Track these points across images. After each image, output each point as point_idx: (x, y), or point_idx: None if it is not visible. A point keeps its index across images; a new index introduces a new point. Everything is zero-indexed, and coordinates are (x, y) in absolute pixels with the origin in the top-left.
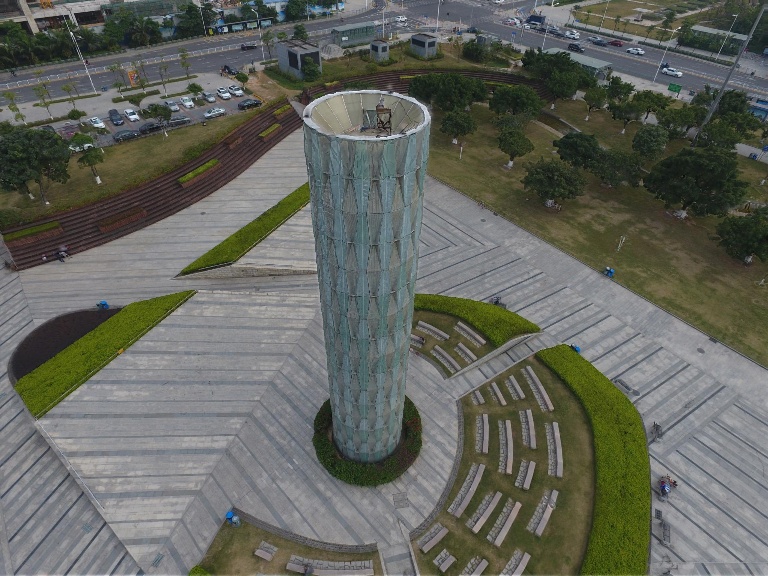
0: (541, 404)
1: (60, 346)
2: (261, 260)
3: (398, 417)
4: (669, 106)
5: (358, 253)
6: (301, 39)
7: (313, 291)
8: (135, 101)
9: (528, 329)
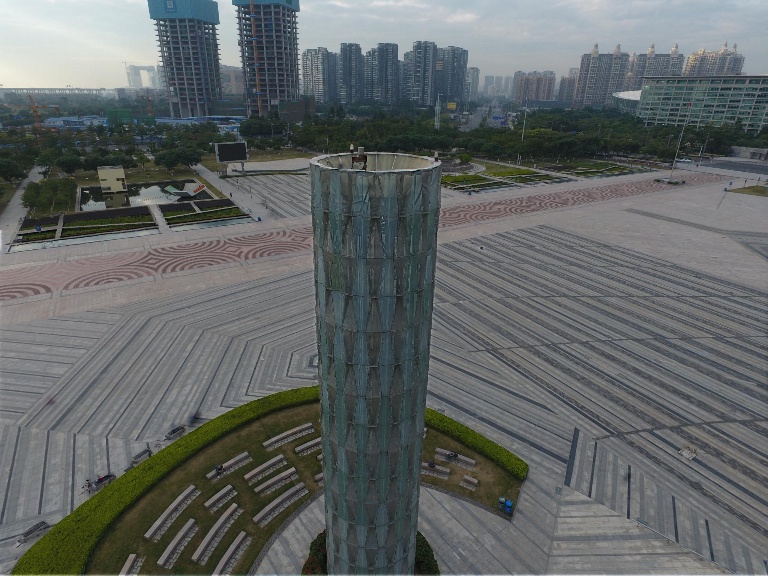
0: (138, 568)
1: None
2: None
3: None
4: None
5: None
6: None
7: None
8: None
9: None
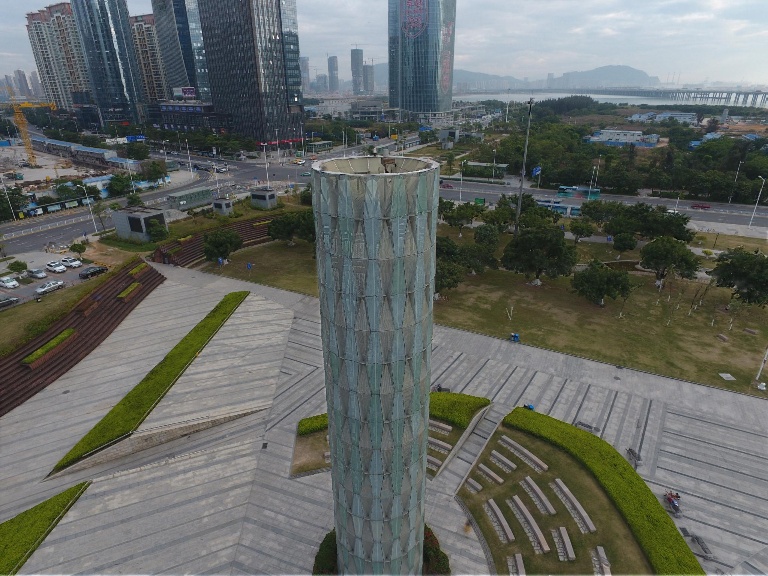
0: (534, 467)
1: None
2: (168, 421)
3: None
4: (485, 211)
5: (394, 306)
6: (140, 205)
7: (244, 437)
8: None
9: (482, 403)
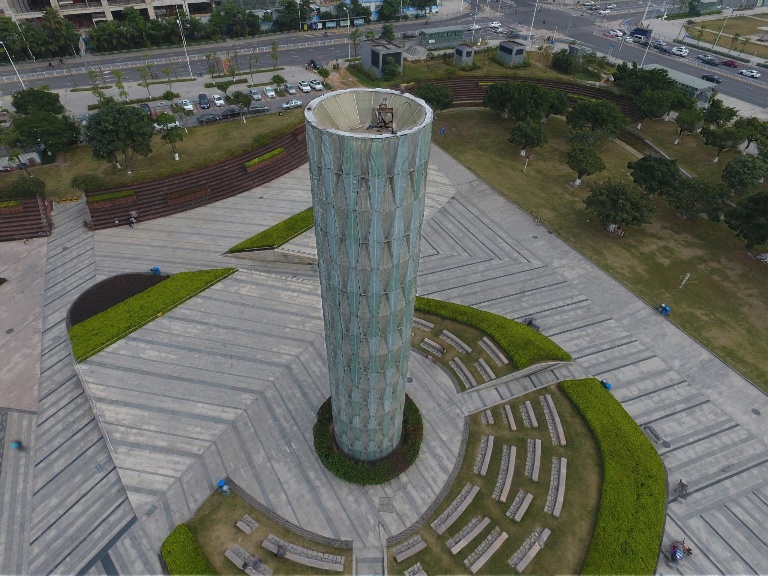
0: (553, 436)
1: (112, 302)
2: (303, 248)
3: (394, 421)
4: None
5: (348, 249)
6: (386, 39)
7: None
8: (222, 87)
9: (557, 356)
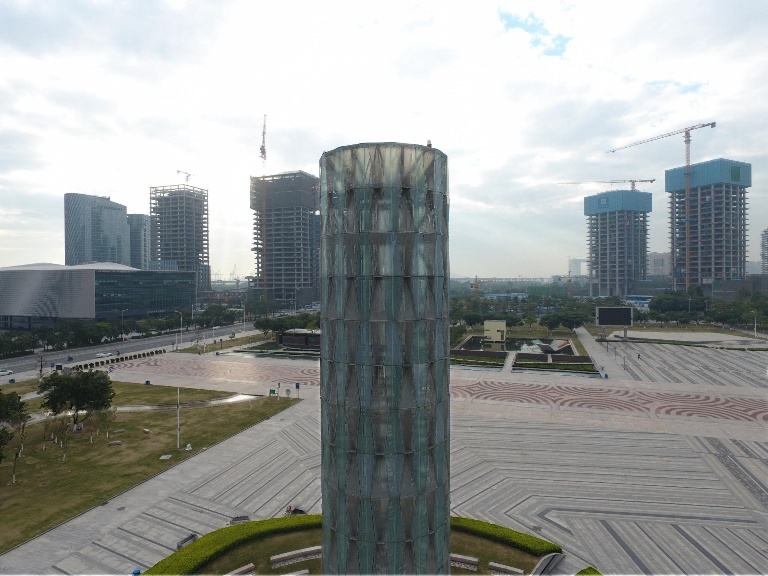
0: None
1: None
2: None
3: None
4: None
5: None
6: None
7: None
8: None
9: None
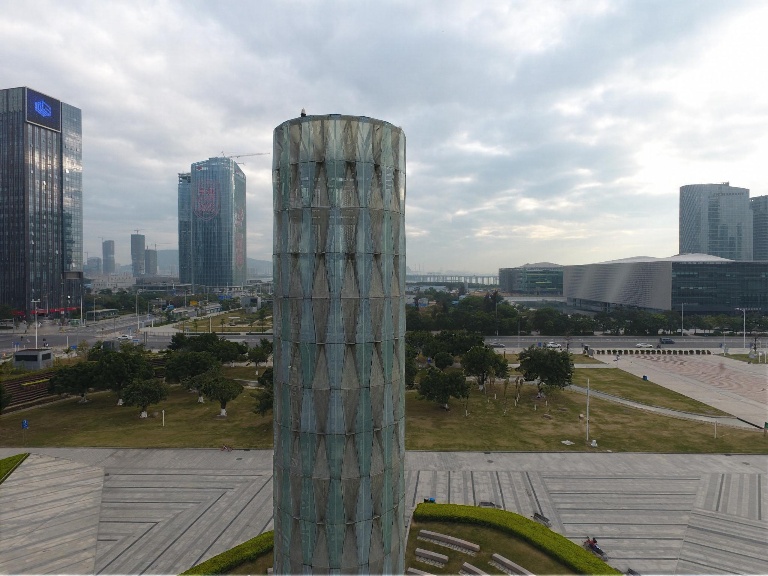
0: (466, 552)
1: None
2: None
3: None
4: None
5: (383, 268)
6: None
7: None
8: None
9: None
